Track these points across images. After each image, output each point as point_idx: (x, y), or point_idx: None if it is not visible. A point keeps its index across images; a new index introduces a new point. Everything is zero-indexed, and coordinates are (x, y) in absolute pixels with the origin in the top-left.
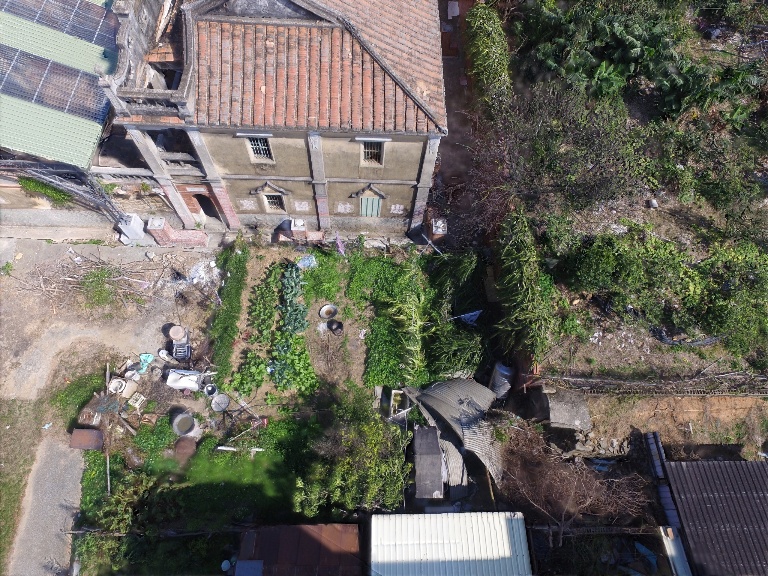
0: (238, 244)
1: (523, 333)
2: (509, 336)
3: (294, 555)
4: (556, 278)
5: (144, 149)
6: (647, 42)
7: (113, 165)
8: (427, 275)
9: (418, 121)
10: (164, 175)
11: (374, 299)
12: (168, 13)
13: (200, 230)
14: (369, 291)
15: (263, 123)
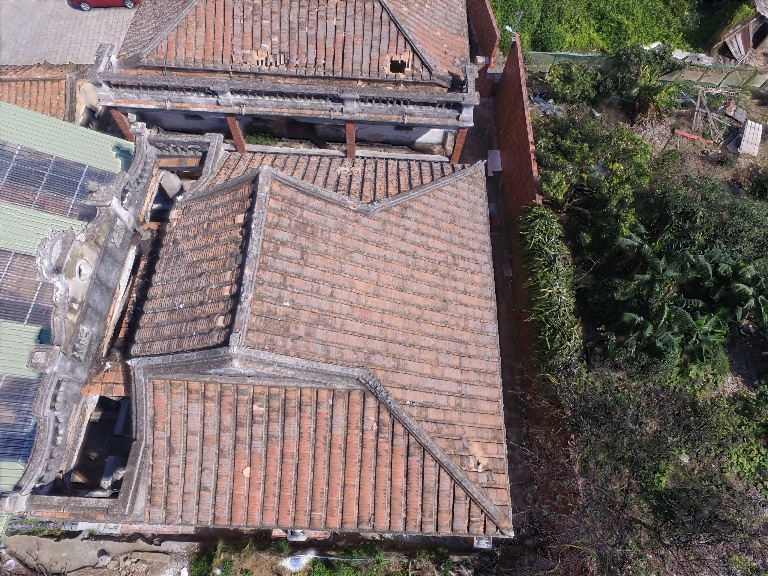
0: None
1: None
2: None
3: None
4: None
5: None
6: (763, 290)
7: None
8: None
9: (471, 520)
10: None
11: None
12: (127, 286)
13: None
14: None
15: (245, 521)
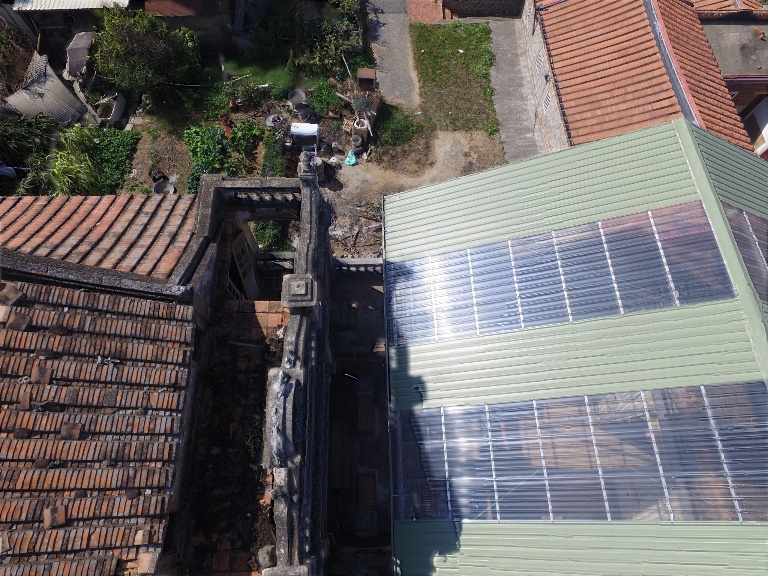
0: None
1: None
2: None
3: (191, 1)
4: None
5: None
6: None
7: None
8: None
9: None
10: None
11: None
12: None
13: None
14: None
15: None
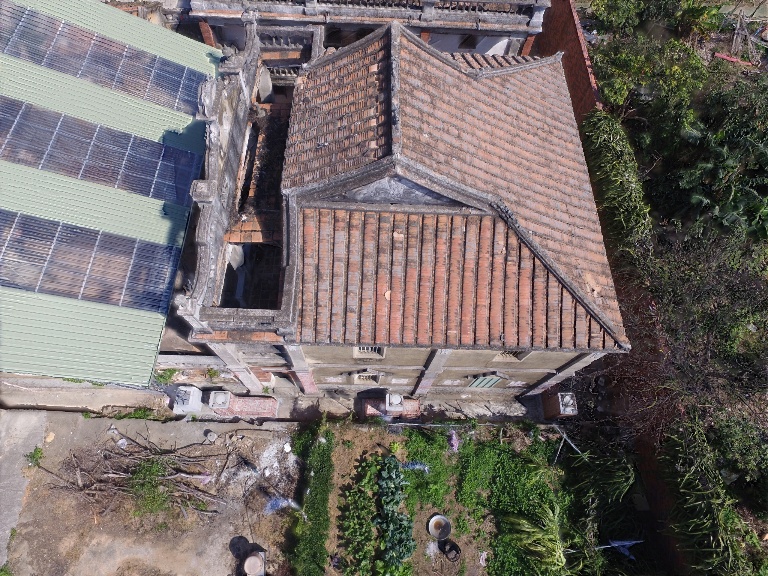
0: (322, 431)
1: None
2: None
3: None
4: (735, 498)
5: (221, 351)
6: None
7: (171, 339)
8: (555, 469)
9: (592, 336)
10: (239, 365)
11: (494, 507)
12: (246, 159)
13: (269, 397)
14: (486, 493)
15: (387, 340)
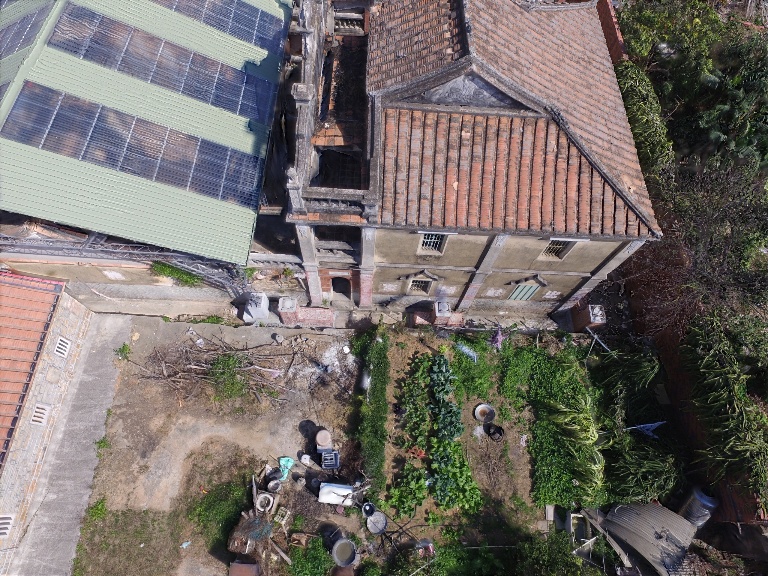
0: (379, 332)
1: (741, 466)
2: (718, 465)
3: None
4: (747, 386)
5: (305, 241)
6: None
7: None
8: None
9: (629, 224)
10: (314, 263)
11: (532, 398)
12: (322, 83)
13: (328, 308)
14: (524, 388)
15: (454, 224)
